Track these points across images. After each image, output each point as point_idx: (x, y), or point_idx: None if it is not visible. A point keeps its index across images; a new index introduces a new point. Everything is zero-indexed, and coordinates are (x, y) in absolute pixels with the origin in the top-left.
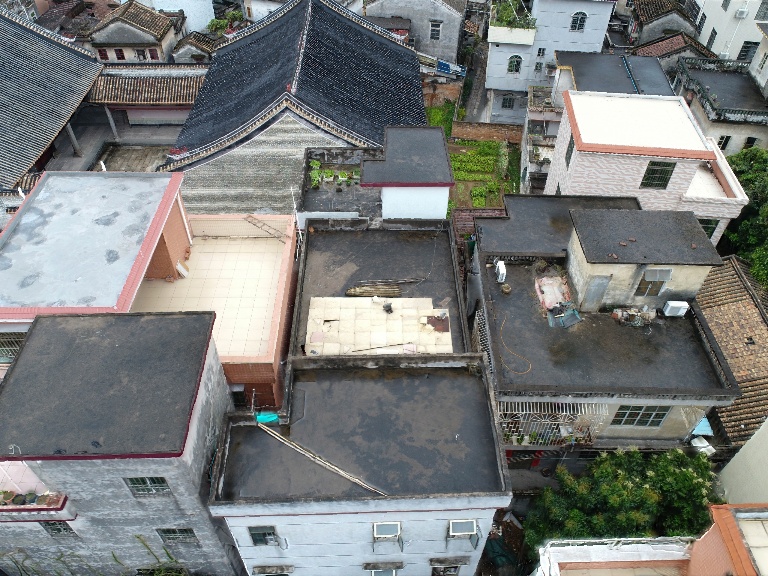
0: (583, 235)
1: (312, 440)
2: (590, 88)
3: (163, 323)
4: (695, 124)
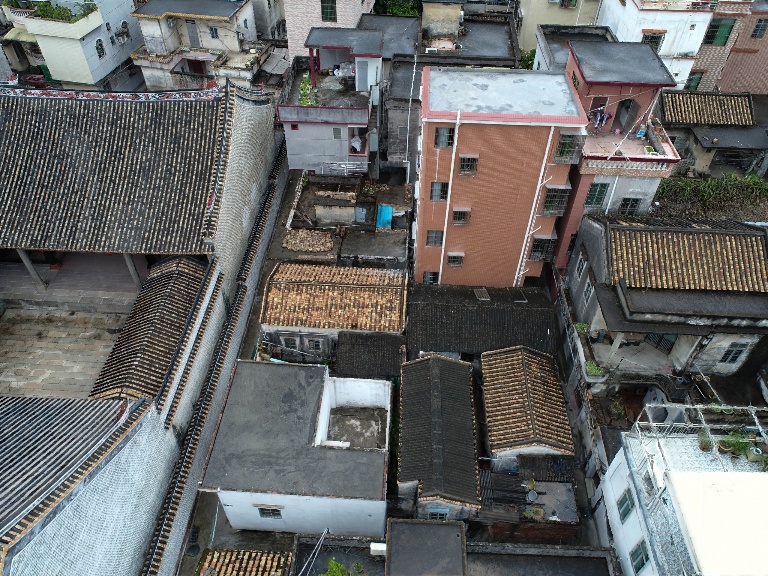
0: (445, 0)
1: None
2: (205, 12)
3: (580, 51)
4: None
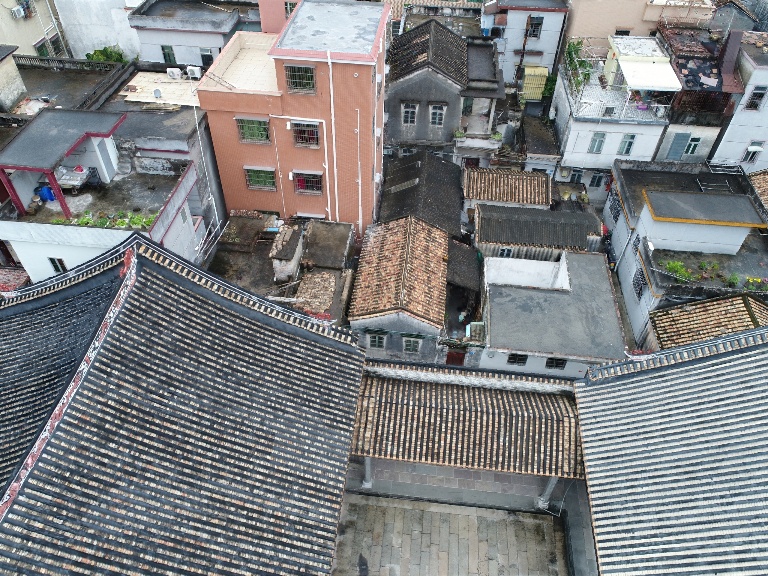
0: None
1: (227, 14)
2: None
3: None
4: None
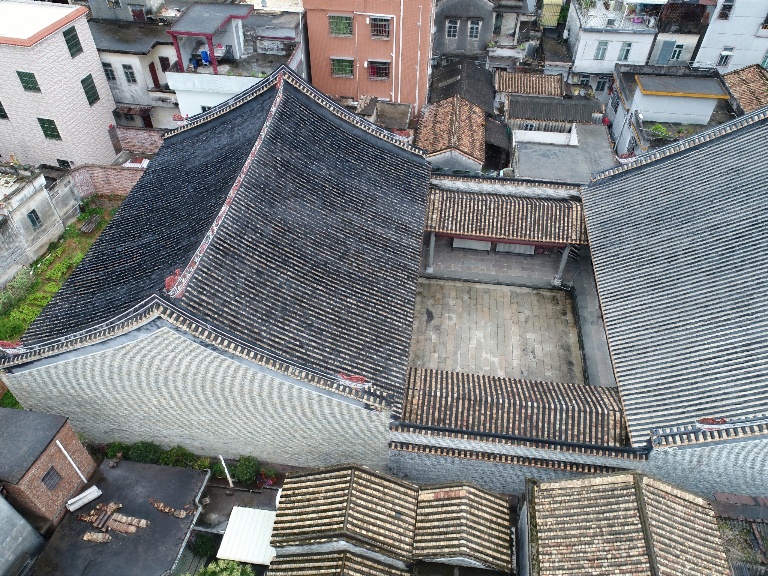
0: None
1: None
2: None
3: None
4: None
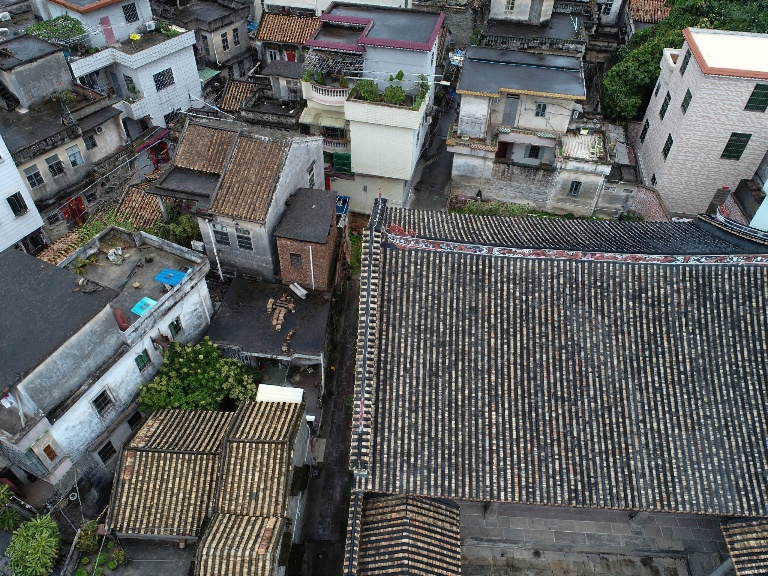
0: None
1: None
2: (547, 87)
3: None
4: (733, 33)
